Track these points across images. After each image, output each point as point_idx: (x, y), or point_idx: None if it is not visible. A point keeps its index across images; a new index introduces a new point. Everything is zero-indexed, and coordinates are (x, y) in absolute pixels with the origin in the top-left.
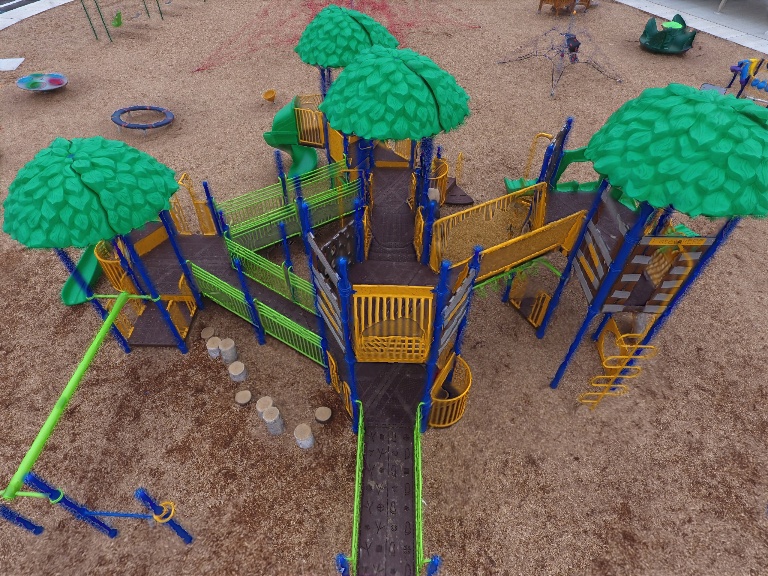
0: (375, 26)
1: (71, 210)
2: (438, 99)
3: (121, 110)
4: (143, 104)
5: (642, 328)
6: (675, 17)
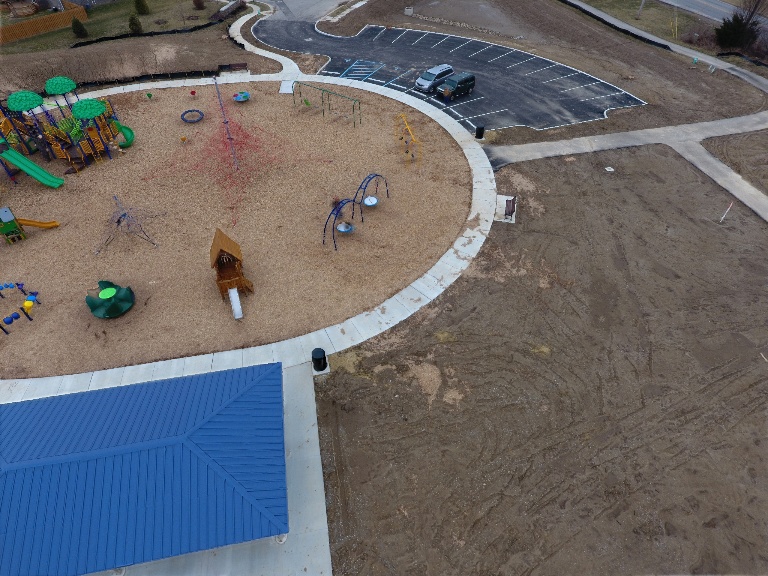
0: (75, 107)
1: None
2: None
3: (199, 111)
4: None
5: None
6: (113, 298)
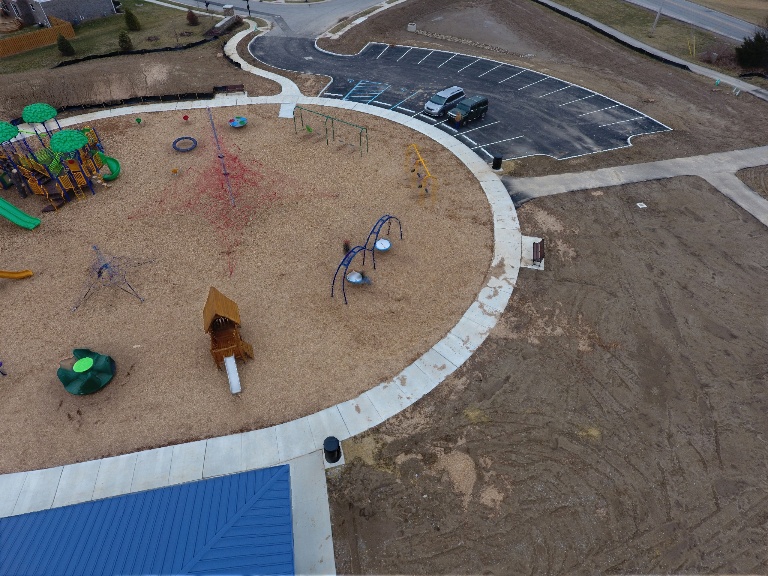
0: (53, 139)
1: None
2: None
3: (192, 138)
4: None
5: None
6: (89, 372)
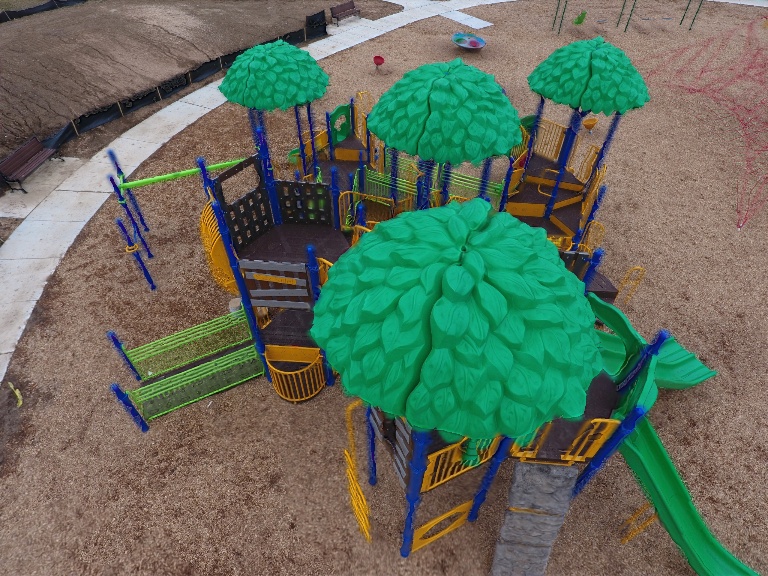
0: (608, 71)
1: (235, 76)
2: (427, 122)
3: None
4: (503, 83)
5: (512, 569)
6: None
